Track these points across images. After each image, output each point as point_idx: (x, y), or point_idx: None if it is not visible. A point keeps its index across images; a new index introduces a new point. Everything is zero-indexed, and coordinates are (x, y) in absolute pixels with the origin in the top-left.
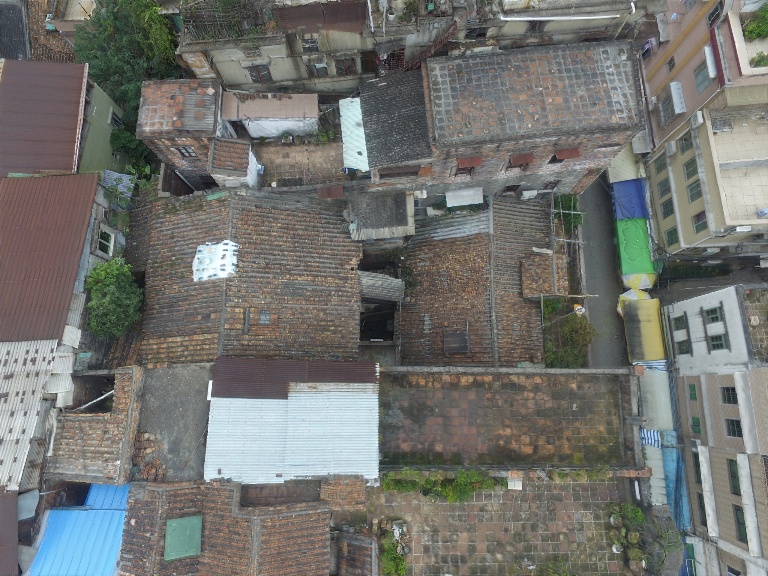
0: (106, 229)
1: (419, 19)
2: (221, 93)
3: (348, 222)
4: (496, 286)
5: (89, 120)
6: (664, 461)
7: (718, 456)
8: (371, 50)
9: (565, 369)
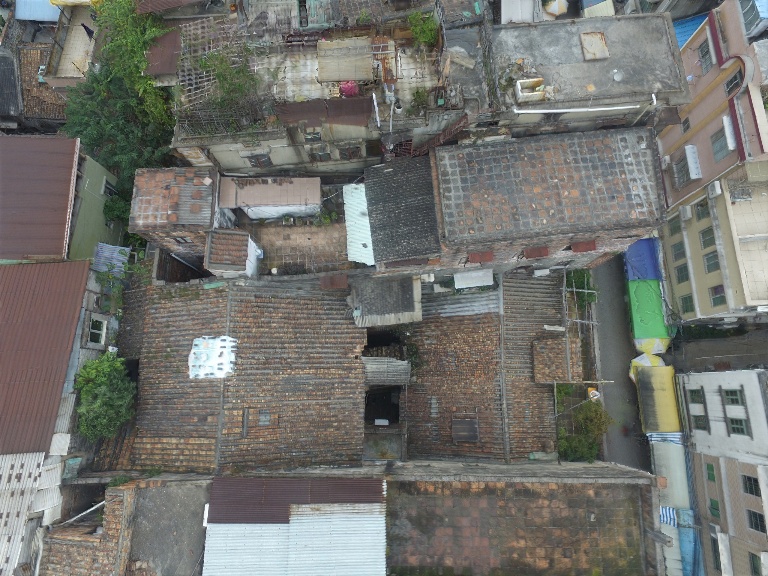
0: (98, 317)
1: (428, 112)
2: (218, 180)
3: (352, 308)
4: (507, 371)
5: (81, 195)
6: (680, 541)
7: (739, 547)
8: (377, 139)
9: (583, 479)
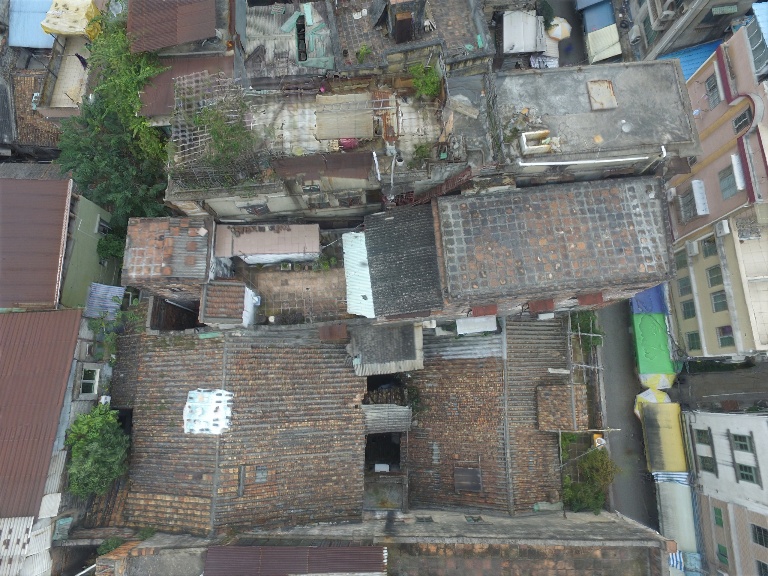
0: (90, 367)
1: (430, 165)
2: (214, 228)
3: (352, 357)
4: (510, 418)
5: (74, 237)
6: None
7: None
8: (377, 188)
9: (590, 541)
